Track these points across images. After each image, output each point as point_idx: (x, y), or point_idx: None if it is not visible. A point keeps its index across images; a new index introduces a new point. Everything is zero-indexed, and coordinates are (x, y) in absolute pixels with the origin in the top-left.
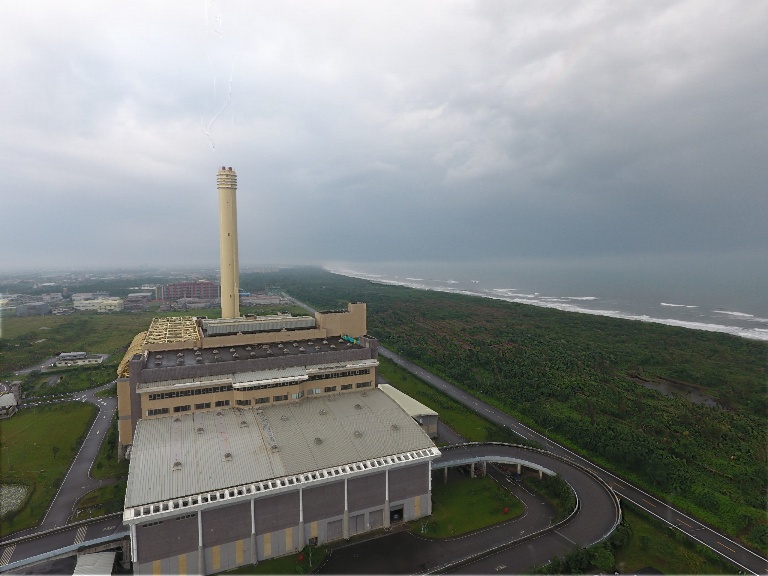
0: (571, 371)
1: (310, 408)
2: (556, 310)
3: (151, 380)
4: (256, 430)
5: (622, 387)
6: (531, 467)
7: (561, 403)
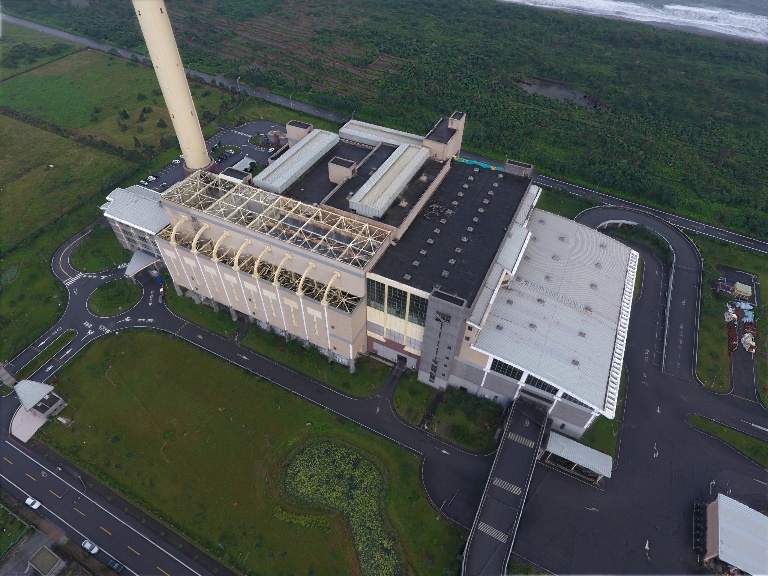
0: (481, 89)
1: (541, 258)
2: None
3: (471, 311)
4: (556, 302)
5: (543, 104)
6: (616, 222)
7: (535, 140)
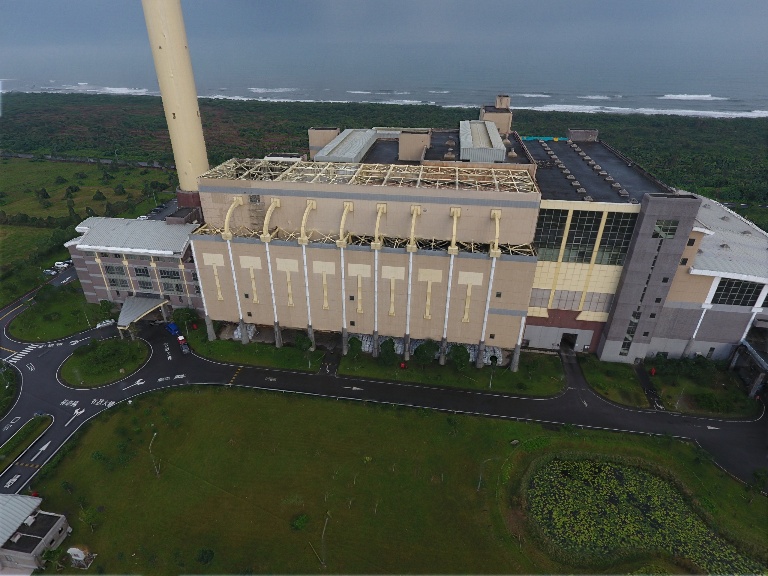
0: None
1: None
2: (266, 101)
3: None
4: None
5: None
6: None
7: None
